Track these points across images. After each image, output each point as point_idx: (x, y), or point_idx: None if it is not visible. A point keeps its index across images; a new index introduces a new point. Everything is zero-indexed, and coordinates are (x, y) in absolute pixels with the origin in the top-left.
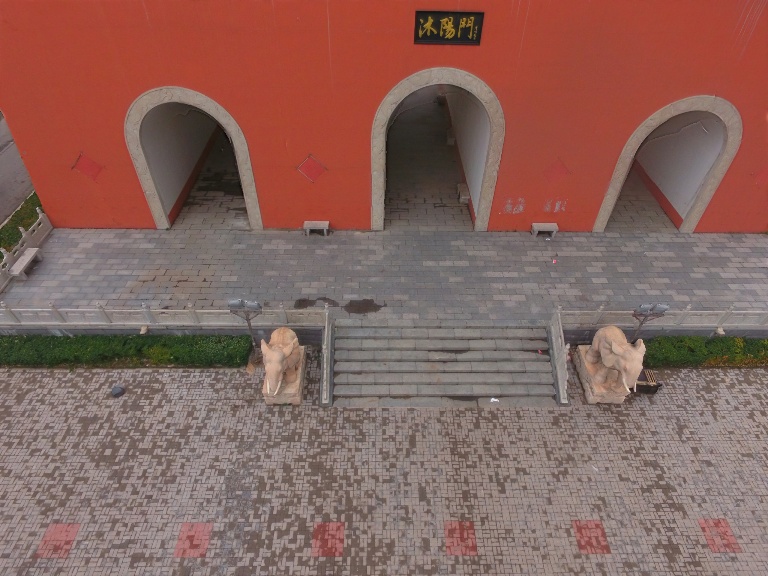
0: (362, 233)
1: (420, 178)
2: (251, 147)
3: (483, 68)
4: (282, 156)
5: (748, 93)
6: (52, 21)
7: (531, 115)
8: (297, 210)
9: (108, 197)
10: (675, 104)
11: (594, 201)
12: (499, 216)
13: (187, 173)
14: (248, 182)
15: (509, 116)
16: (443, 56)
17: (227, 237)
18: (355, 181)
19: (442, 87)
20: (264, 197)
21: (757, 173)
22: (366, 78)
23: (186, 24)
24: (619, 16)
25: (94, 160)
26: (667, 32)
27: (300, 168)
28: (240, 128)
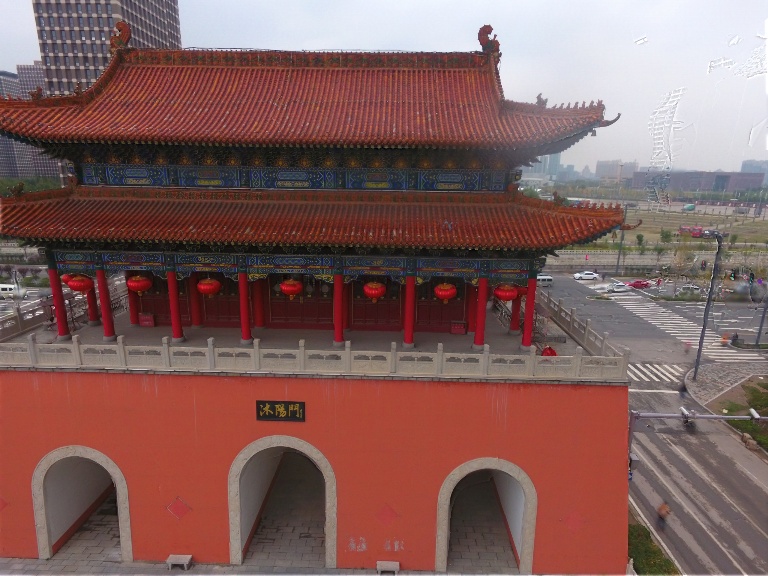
0: (220, 568)
1: (299, 503)
2: (131, 490)
3: (311, 436)
4: (155, 497)
5: (524, 456)
6: (3, 404)
7: (355, 469)
8: (165, 543)
9: (5, 528)
10: (468, 463)
11: (428, 541)
12: (345, 553)
13: (94, 498)
14: (125, 518)
15: (338, 470)
16: (279, 428)
17: (96, 570)
18: (215, 519)
19: (281, 448)
20: (137, 531)
21: (565, 519)
22: (223, 441)
23: (95, 406)
24: (403, 404)
25: (3, 498)
26: (442, 415)
27: (169, 507)
28: (123, 476)
